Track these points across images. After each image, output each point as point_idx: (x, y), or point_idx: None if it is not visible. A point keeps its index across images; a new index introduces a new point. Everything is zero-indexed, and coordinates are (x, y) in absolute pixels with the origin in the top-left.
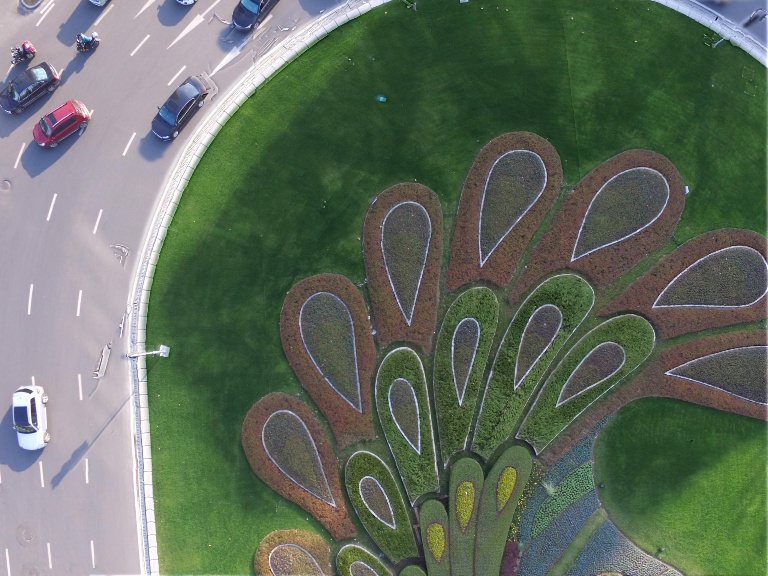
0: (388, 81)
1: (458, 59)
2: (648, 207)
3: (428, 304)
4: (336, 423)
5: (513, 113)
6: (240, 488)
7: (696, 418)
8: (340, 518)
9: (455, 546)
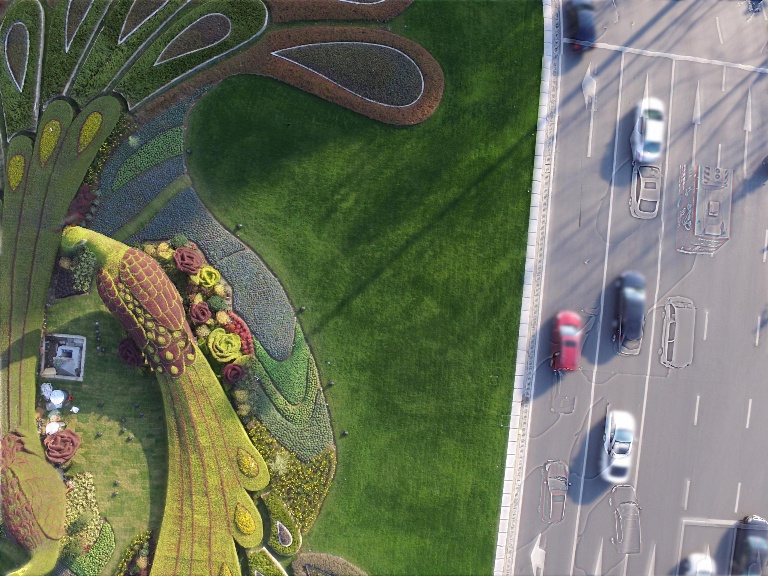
0: None
1: None
2: None
3: None
4: None
5: None
6: None
7: (297, 103)
8: None
9: (31, 178)
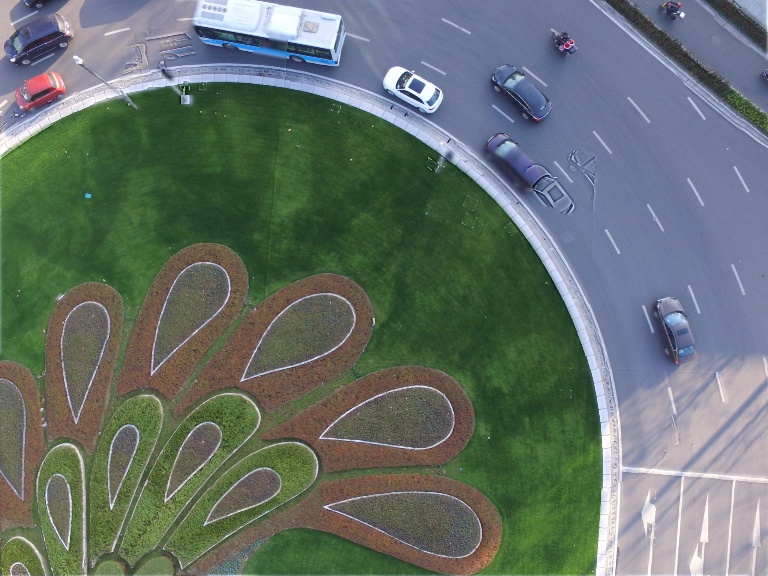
0: (96, 178)
1: (166, 162)
2: (328, 335)
3: (95, 405)
4: None
5: (209, 223)
6: None
7: (353, 556)
8: None
9: None
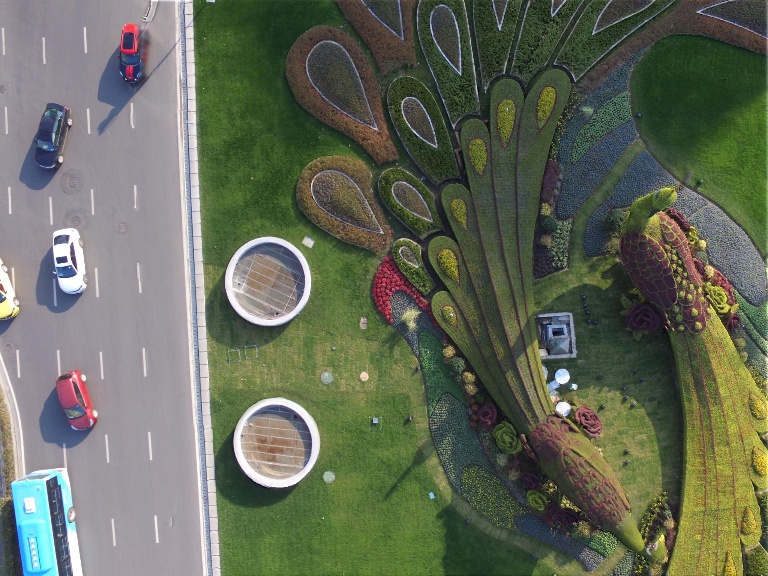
0: None
1: None
2: None
3: None
4: (379, 50)
5: None
6: (283, 119)
7: (728, 58)
8: (382, 140)
9: (497, 160)
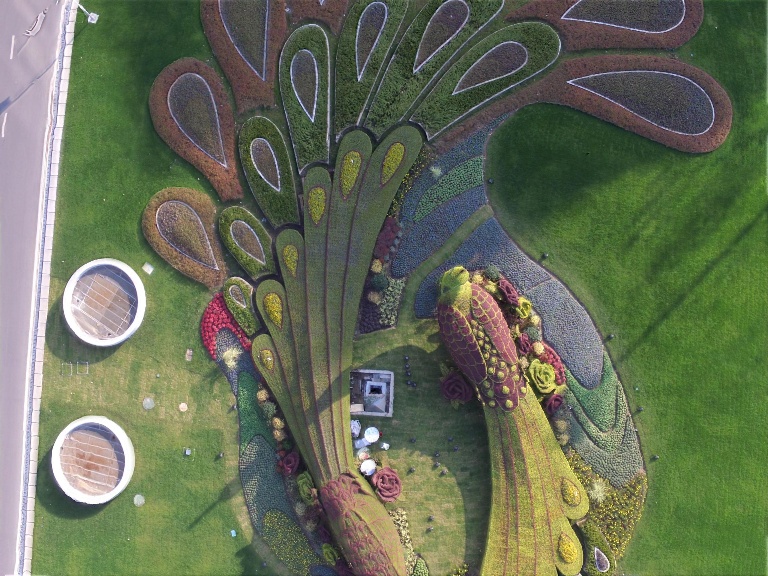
0: None
1: None
2: None
3: None
4: (238, 88)
5: None
6: (140, 145)
7: (595, 132)
8: (229, 178)
9: (334, 211)
